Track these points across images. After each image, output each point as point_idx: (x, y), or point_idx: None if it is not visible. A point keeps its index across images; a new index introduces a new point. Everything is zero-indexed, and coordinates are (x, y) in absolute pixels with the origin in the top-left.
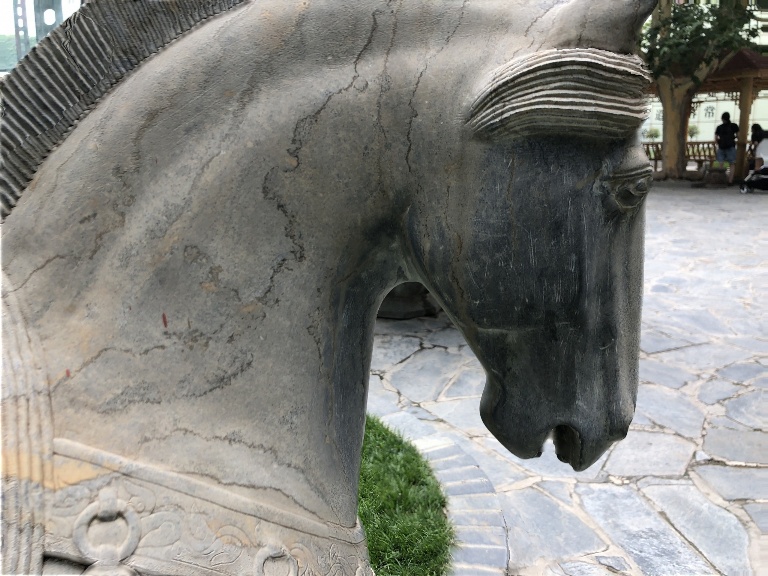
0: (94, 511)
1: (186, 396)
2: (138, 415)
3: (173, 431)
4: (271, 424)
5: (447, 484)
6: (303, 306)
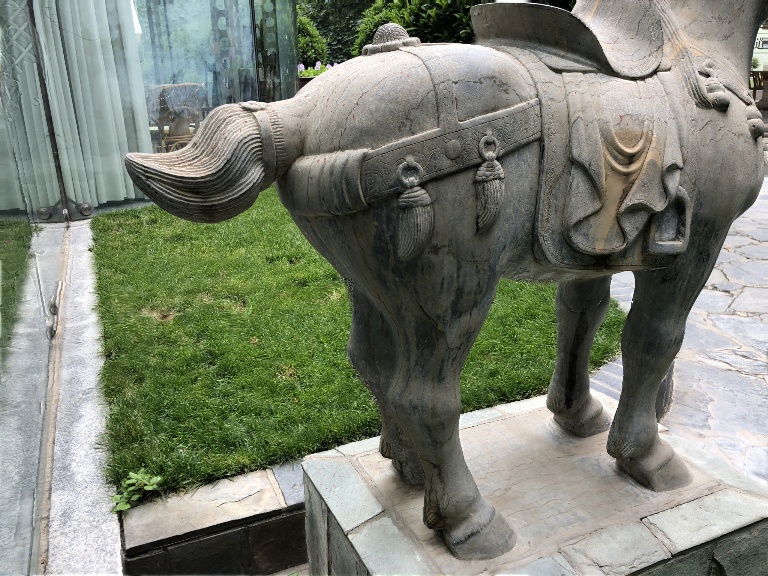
0: (706, 64)
1: (717, 40)
2: (706, 43)
3: (714, 50)
4: (737, 58)
5: (616, 296)
6: (750, 14)
